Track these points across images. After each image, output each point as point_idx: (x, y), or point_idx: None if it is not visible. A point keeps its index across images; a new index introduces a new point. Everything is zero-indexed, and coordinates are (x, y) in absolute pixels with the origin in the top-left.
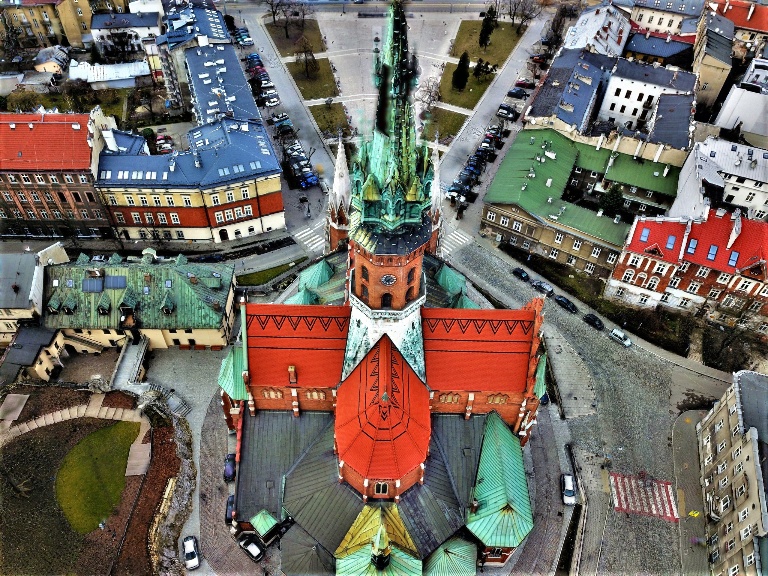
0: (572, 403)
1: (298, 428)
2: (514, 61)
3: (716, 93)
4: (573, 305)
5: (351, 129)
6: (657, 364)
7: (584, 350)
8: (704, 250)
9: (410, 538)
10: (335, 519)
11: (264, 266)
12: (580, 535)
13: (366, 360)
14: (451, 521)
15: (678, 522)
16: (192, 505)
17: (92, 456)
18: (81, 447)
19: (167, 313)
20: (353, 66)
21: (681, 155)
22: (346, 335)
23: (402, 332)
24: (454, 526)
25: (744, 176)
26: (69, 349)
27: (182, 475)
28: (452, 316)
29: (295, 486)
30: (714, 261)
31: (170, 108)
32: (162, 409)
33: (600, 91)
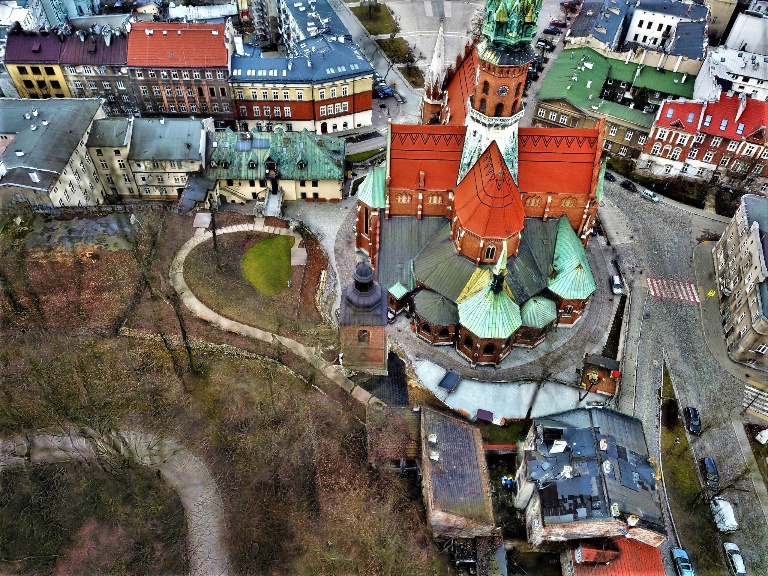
0: (615, 236)
1: (420, 227)
2: (547, 7)
3: (724, 26)
4: (611, 175)
5: (414, 56)
6: (680, 213)
7: (622, 205)
8: (717, 123)
9: (510, 290)
10: (455, 279)
11: (359, 150)
12: (627, 309)
13: (478, 163)
14: (537, 283)
15: (699, 304)
16: (337, 292)
17: (264, 254)
18: (255, 249)
19: (301, 168)
20: (408, 10)
21: (696, 64)
22: (462, 149)
23: (506, 139)
24: (539, 287)
25: (748, 75)
26: (221, 199)
27: (329, 271)
28: (539, 133)
29: (422, 264)
30: (725, 131)
31: (259, 40)
32: (308, 229)
33: (625, 24)
